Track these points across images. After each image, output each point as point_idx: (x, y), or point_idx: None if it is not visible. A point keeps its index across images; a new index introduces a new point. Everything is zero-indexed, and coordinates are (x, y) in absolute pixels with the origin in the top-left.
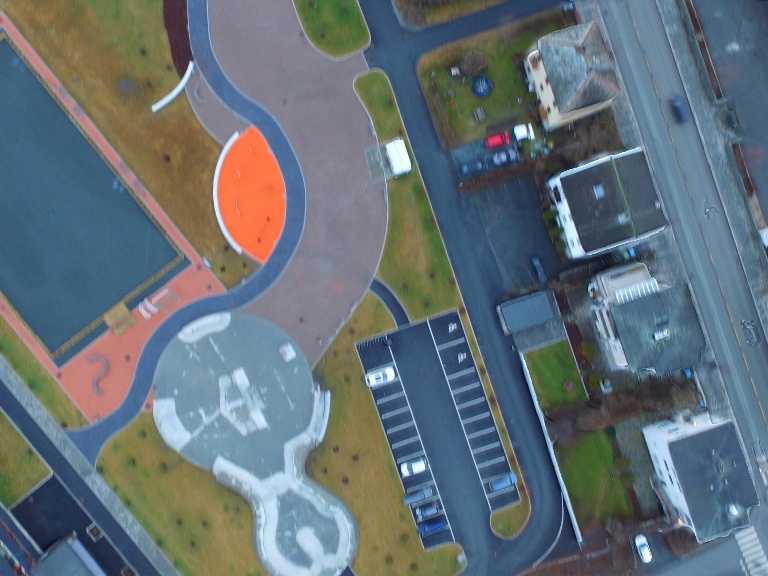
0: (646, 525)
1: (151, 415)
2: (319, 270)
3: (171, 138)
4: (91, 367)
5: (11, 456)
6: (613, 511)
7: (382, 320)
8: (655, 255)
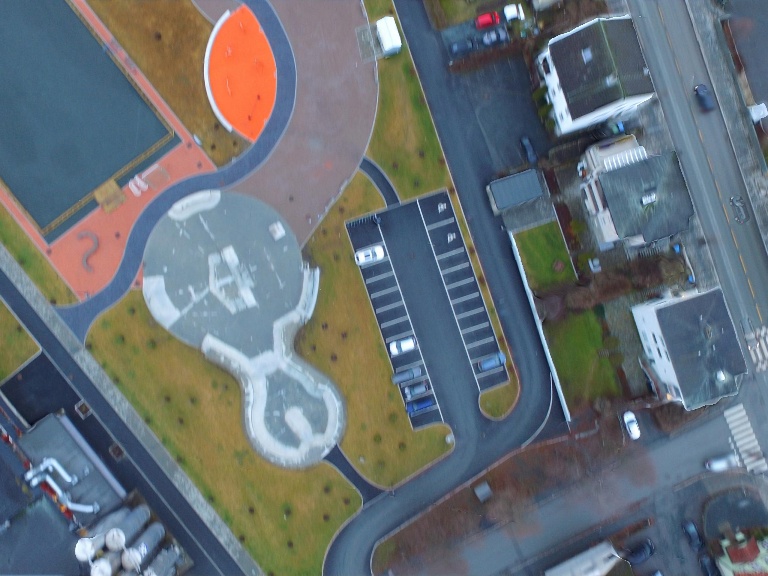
0: (635, 402)
1: (140, 292)
2: (309, 149)
3: (162, 16)
4: (81, 244)
5: (0, 333)
6: (602, 392)
7: (372, 199)
8: (644, 131)
